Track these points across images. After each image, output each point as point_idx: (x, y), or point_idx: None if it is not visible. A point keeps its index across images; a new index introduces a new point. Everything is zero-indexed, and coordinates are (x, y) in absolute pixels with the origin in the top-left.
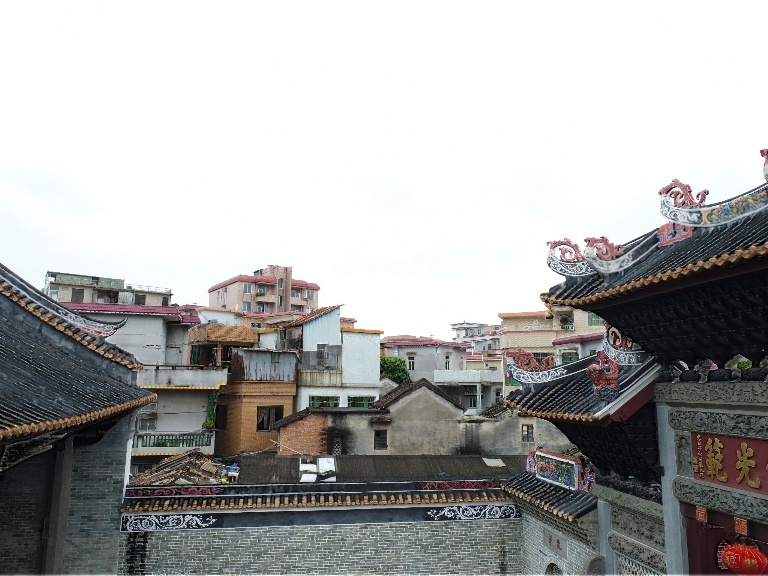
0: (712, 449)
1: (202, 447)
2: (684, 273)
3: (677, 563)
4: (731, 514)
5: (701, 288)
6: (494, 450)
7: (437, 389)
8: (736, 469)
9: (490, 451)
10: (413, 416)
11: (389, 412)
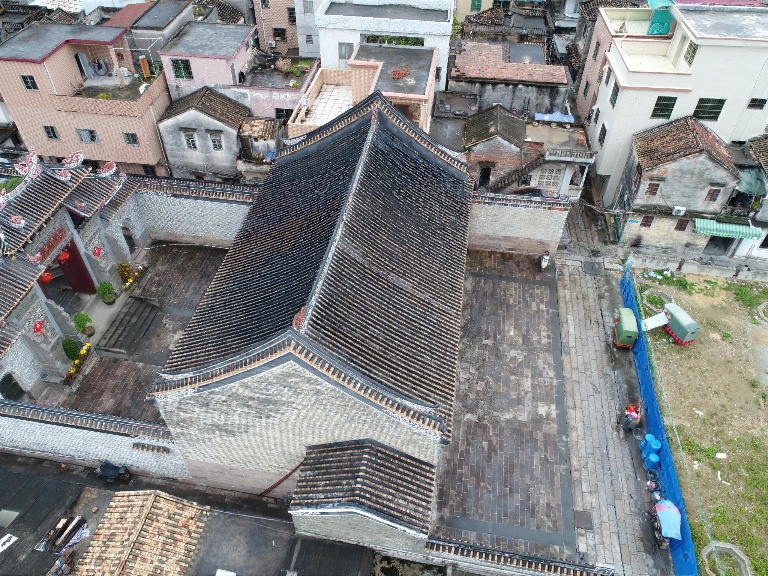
0: None
1: None
2: None
3: (44, 295)
4: None
5: None
6: None
7: None
8: None
9: None
10: None
11: None
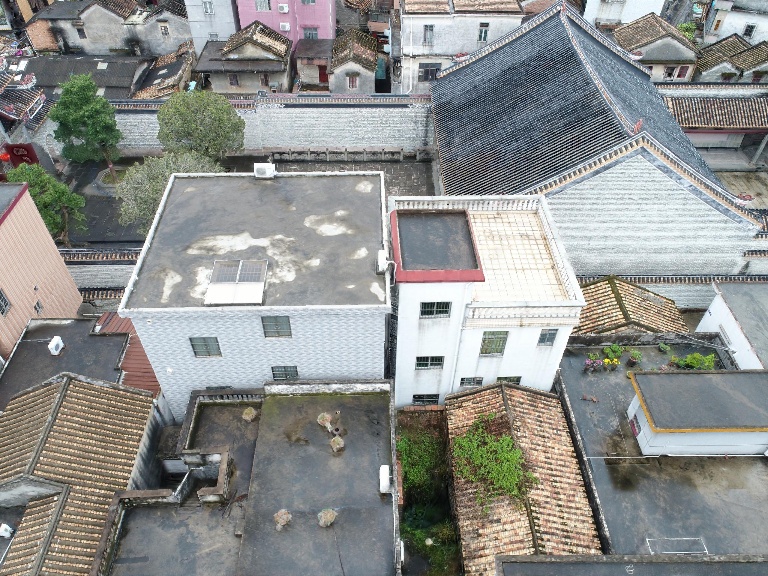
0: None
1: (4, 26)
2: None
3: None
4: None
5: None
6: (147, 40)
7: (104, 5)
8: None
9: (145, 40)
10: (95, 21)
11: (80, 19)
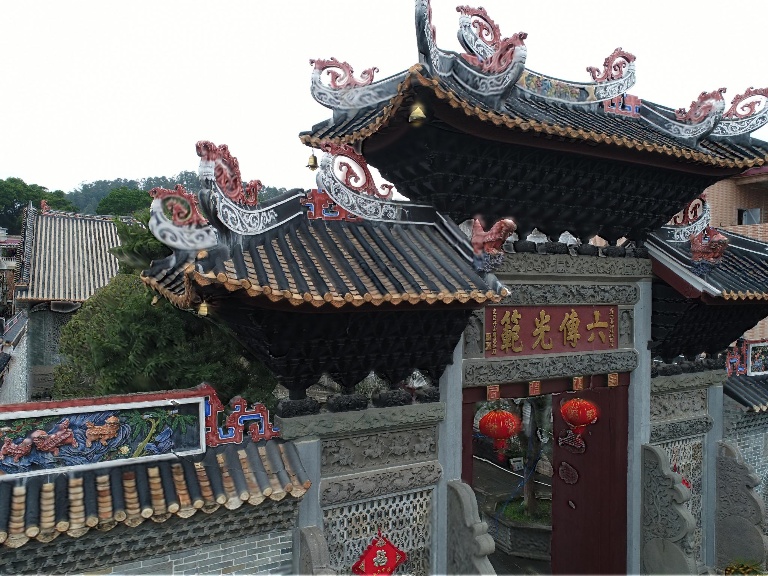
0: (510, 321)
1: None
2: (649, 149)
3: None
4: (526, 380)
5: (603, 163)
6: None
7: None
8: (532, 336)
9: None
10: None
11: None
